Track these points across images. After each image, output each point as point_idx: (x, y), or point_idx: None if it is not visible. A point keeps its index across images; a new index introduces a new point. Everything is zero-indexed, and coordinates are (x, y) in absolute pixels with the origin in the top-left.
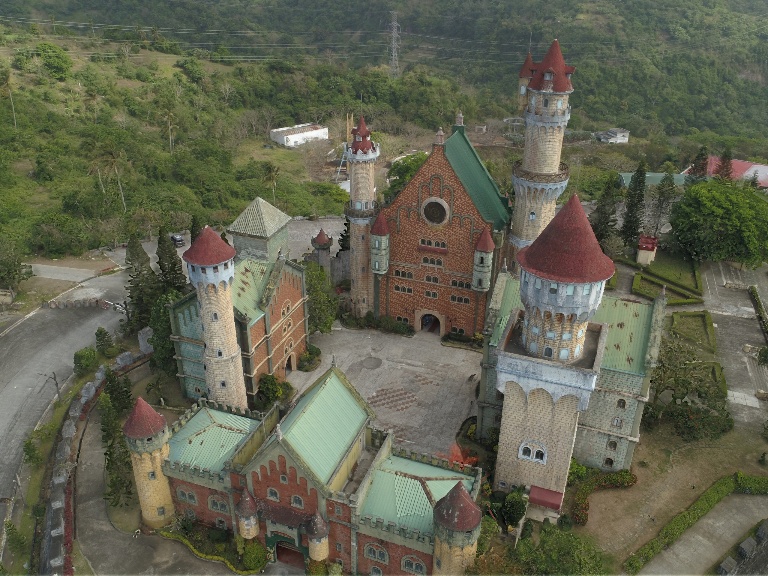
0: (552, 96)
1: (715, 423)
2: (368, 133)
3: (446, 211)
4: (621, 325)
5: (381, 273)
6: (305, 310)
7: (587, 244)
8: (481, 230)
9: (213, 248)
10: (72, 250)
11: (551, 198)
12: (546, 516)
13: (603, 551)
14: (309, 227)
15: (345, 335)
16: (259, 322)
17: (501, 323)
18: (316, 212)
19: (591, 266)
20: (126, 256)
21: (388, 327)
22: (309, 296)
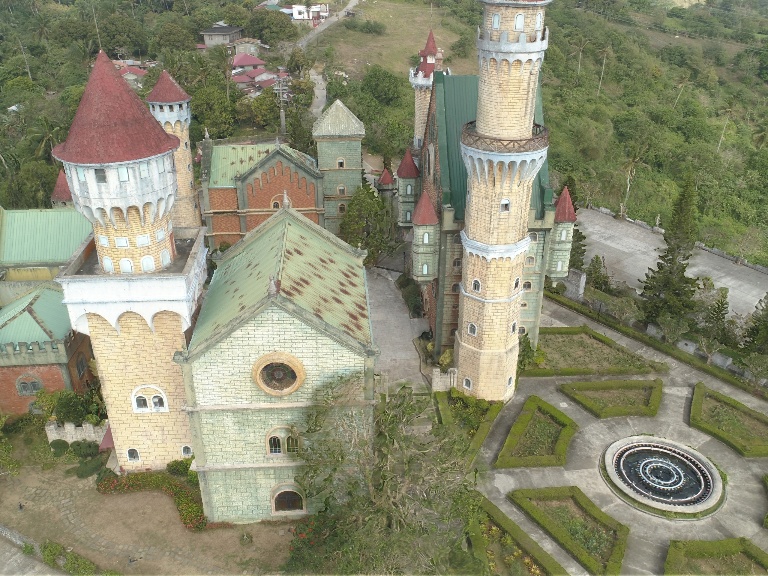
0: (487, 6)
1: (309, 571)
2: (429, 54)
3: (431, 163)
4: (243, 308)
5: (399, 224)
6: (320, 223)
7: (82, 114)
8: (441, 199)
9: (157, 89)
10: (384, 152)
11: (485, 176)
12: (117, 463)
13: (70, 520)
14: (597, 221)
15: (381, 284)
16: (229, 192)
17: (237, 256)
18: (624, 211)
19: (73, 142)
20: (292, 132)
21: (403, 294)
22: (345, 217)
